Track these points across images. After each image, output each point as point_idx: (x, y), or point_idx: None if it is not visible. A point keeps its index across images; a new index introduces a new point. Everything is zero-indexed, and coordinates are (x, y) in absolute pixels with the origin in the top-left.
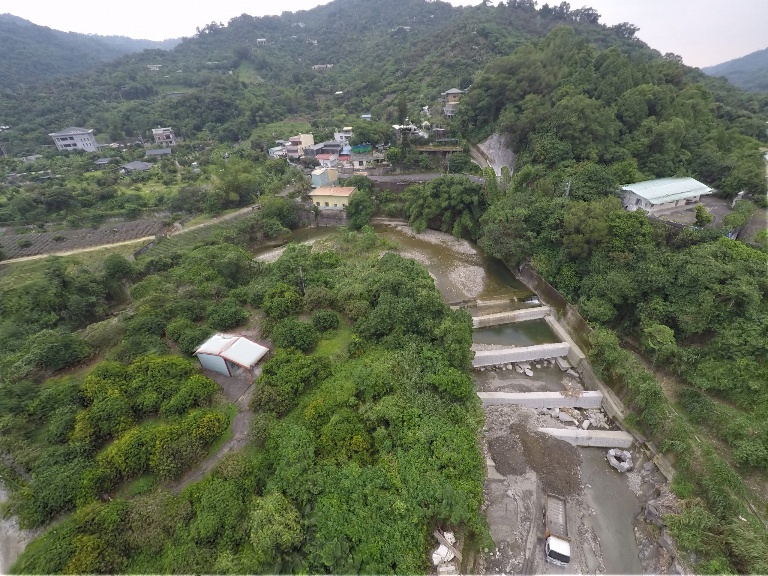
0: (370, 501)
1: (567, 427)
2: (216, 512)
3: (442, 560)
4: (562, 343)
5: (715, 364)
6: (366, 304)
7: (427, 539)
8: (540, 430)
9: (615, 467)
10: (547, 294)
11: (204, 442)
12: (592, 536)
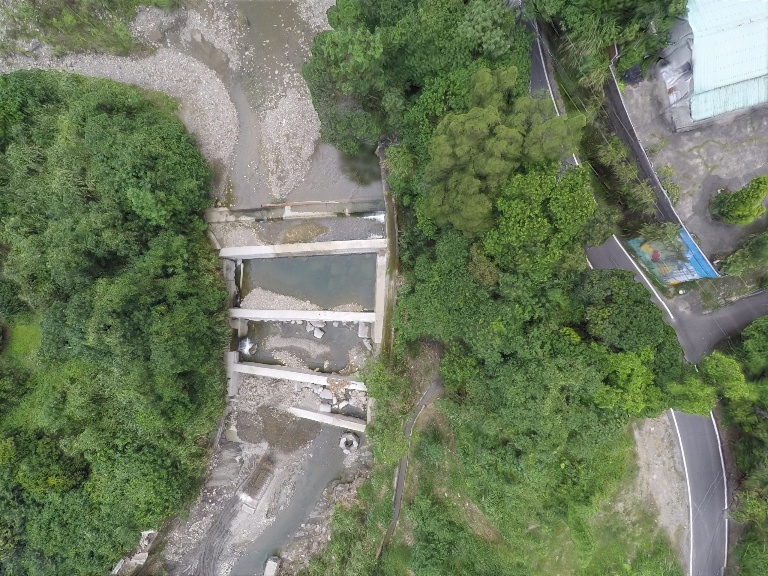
0: None
1: (320, 408)
2: None
3: None
4: (367, 314)
5: (470, 438)
6: (47, 291)
7: None
8: (289, 411)
9: None
10: (390, 225)
11: None
12: (291, 488)
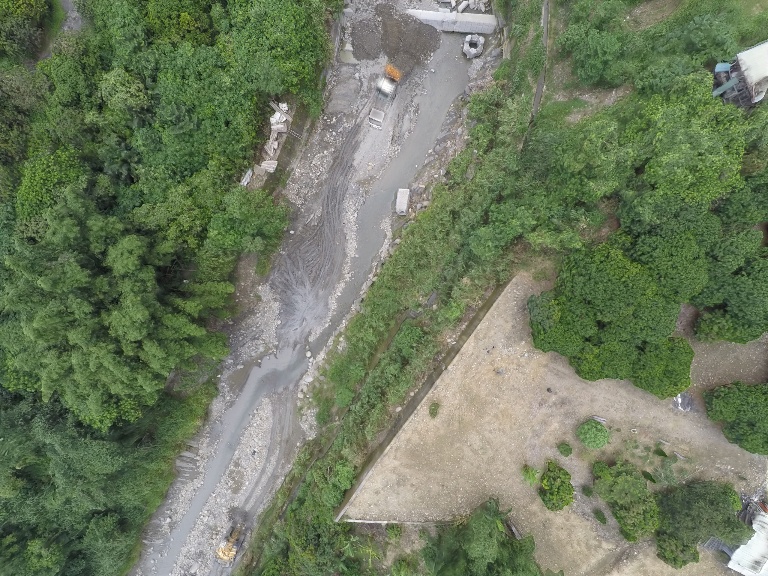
0: (203, 76)
1: (439, 9)
2: (65, 81)
3: (277, 122)
4: None
5: None
6: None
7: (259, 106)
8: (408, 12)
9: (466, 53)
10: None
11: (29, 17)
12: (415, 110)
